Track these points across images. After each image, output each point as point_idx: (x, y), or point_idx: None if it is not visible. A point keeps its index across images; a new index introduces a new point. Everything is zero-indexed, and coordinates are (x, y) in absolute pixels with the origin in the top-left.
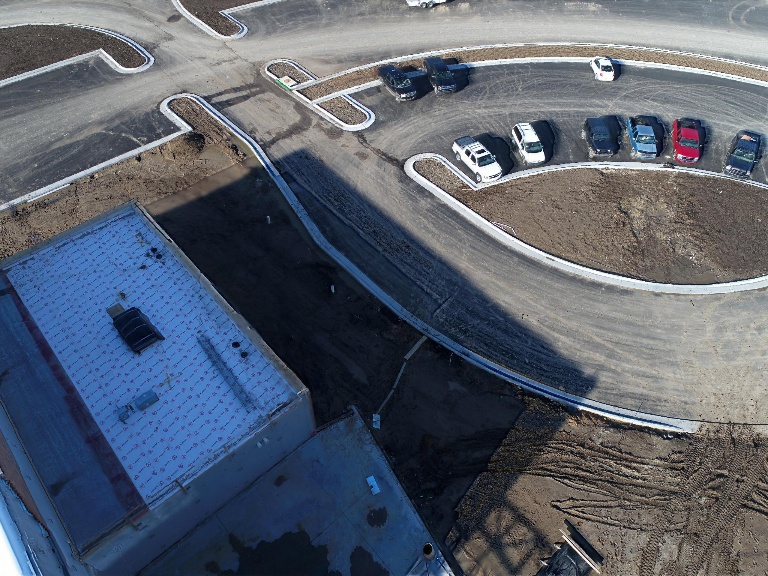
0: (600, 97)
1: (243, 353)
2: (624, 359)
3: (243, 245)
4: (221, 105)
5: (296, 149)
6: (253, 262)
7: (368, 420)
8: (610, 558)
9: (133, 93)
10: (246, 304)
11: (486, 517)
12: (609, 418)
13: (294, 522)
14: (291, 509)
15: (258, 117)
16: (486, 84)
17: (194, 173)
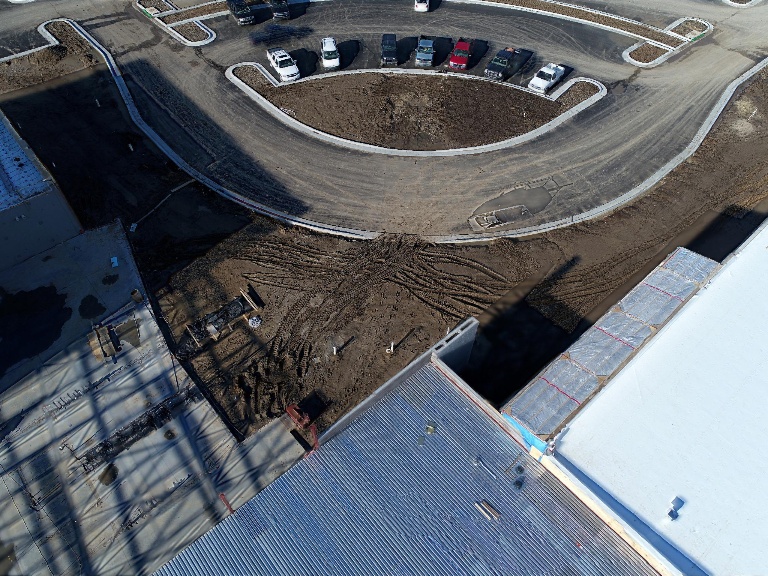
0: (412, 24)
1: (20, 164)
2: (343, 195)
3: (73, 120)
4: (90, 27)
5: (141, 58)
6: (77, 131)
7: (127, 227)
8: (271, 304)
9: (19, 17)
10: (61, 157)
11: (191, 282)
12: (314, 230)
13: (48, 281)
14: (49, 274)
15: (118, 36)
16: (319, 14)
17: (51, 73)
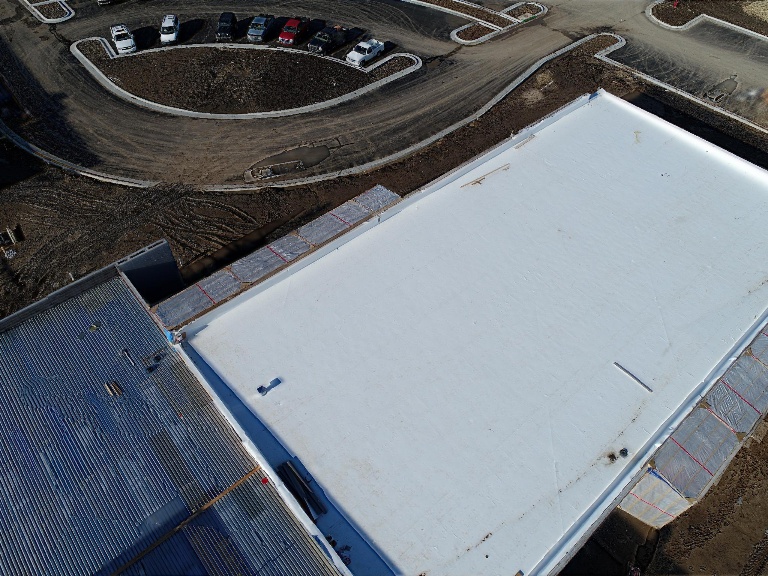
0: (262, 5)
1: None
2: (137, 151)
3: None
4: None
5: None
6: None
7: None
8: (31, 239)
9: None
10: None
11: None
12: (99, 180)
13: None
14: None
15: None
16: None
17: None
